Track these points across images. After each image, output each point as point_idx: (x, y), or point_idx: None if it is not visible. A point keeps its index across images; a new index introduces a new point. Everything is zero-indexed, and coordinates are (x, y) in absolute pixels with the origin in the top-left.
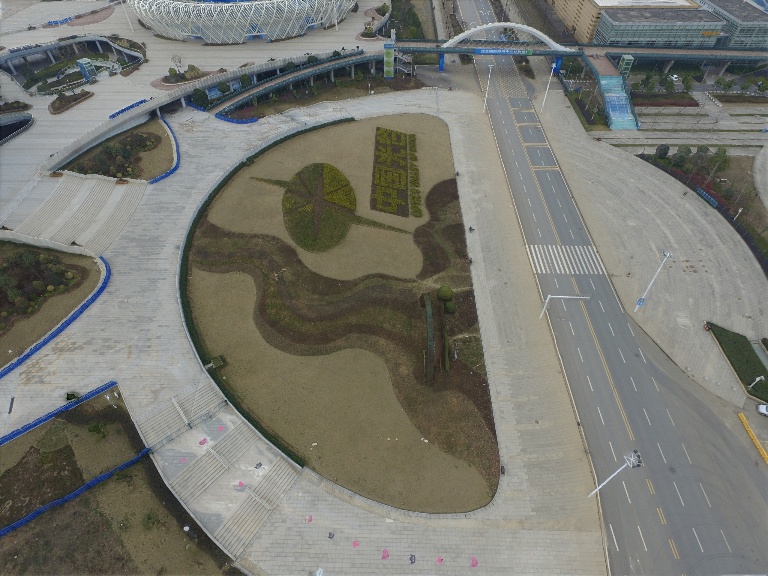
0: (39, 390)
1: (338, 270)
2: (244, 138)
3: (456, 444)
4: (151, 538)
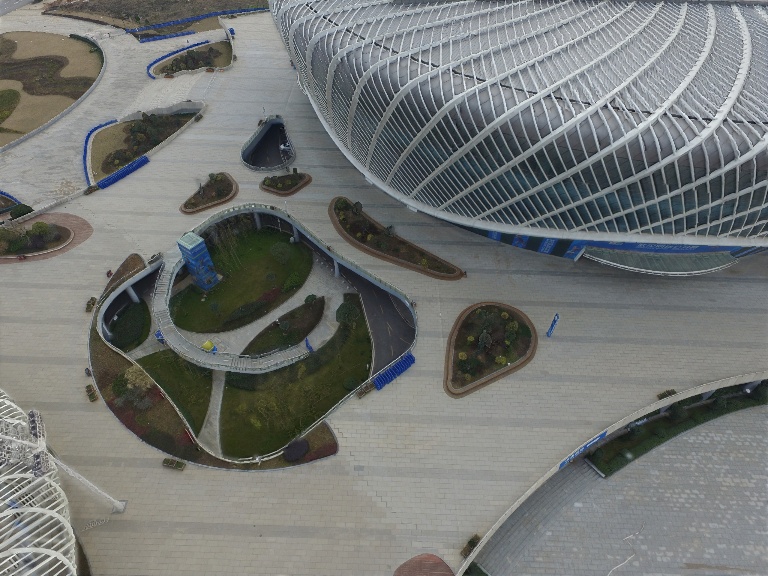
0: (177, 43)
1: (2, 83)
2: (3, 169)
3: (4, 41)
4: (131, 26)
